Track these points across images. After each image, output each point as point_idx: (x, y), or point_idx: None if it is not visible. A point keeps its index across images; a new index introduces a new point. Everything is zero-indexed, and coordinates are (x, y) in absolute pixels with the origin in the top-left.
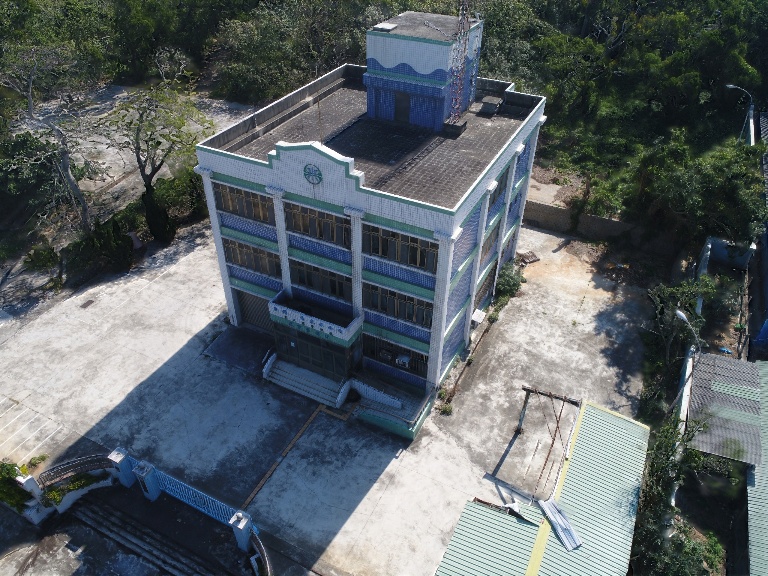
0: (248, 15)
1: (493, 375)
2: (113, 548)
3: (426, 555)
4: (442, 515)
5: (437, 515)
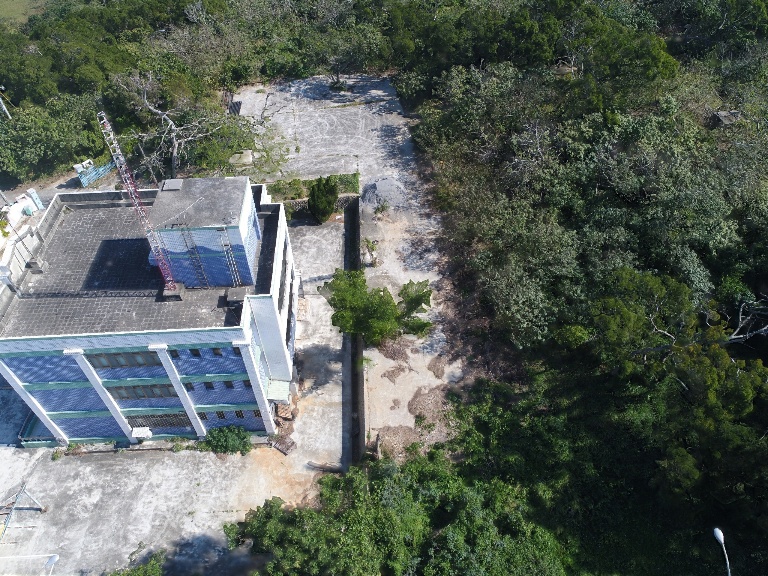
0: (492, 67)
1: (103, 472)
2: None
3: None
4: None
5: None
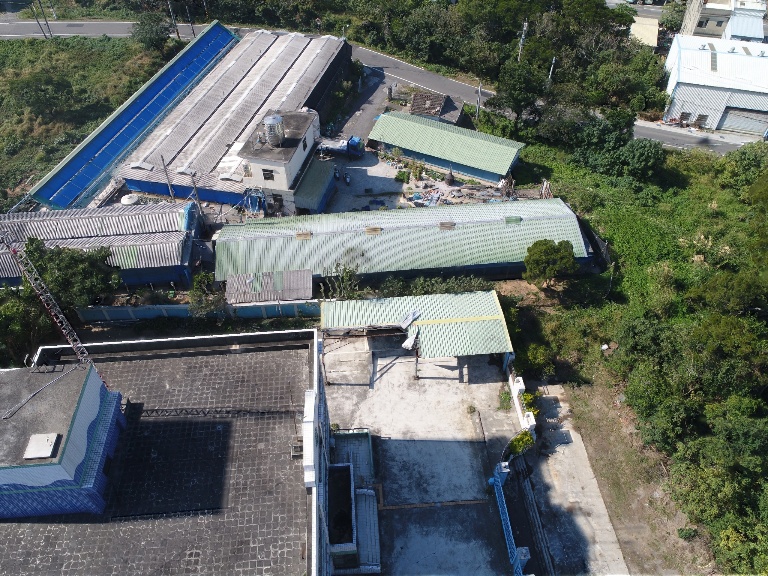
0: None
1: None
2: (558, 569)
3: (438, 395)
4: (411, 398)
5: (412, 400)
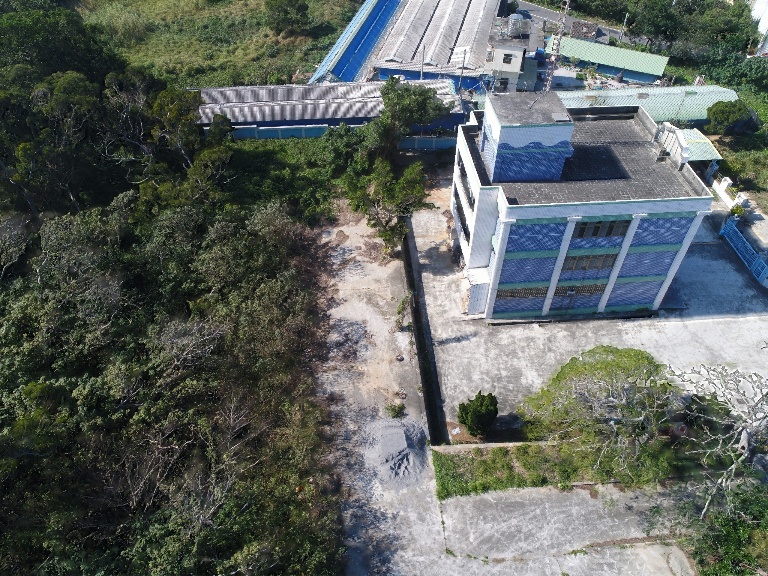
0: None
1: None
2: None
3: None
4: None
5: None
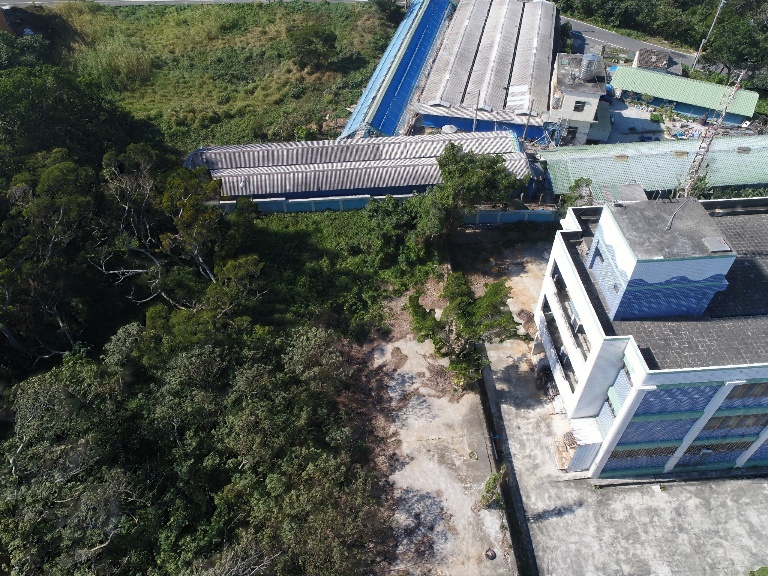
0: None
1: None
2: None
3: None
4: None
5: None
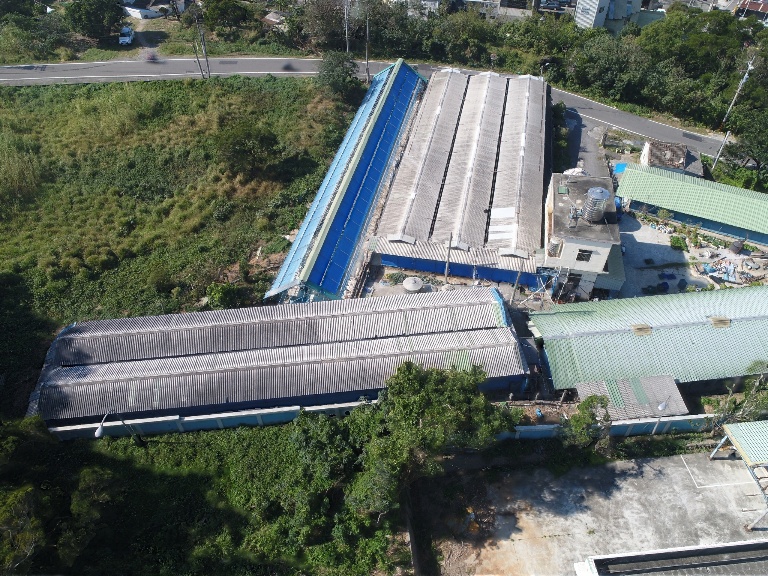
0: None
1: None
2: None
3: None
4: None
5: None
